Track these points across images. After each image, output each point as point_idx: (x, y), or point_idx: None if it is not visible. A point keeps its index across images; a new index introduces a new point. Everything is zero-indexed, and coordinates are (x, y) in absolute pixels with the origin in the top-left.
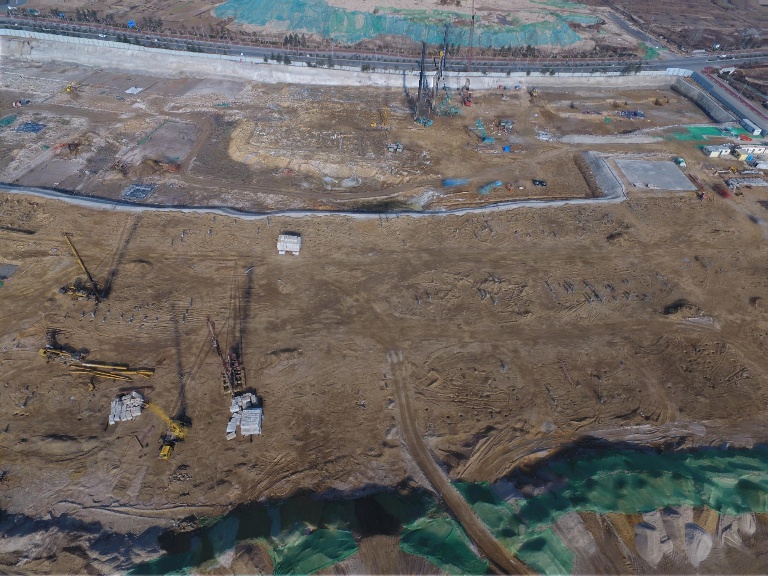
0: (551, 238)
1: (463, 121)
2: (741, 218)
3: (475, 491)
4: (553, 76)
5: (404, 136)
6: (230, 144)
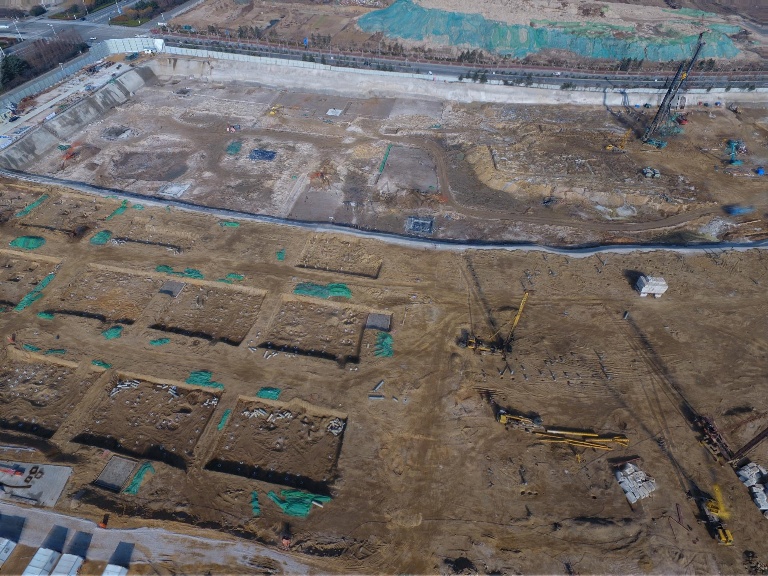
0: None
1: (690, 141)
2: None
3: None
4: (751, 92)
5: (646, 159)
6: (476, 170)
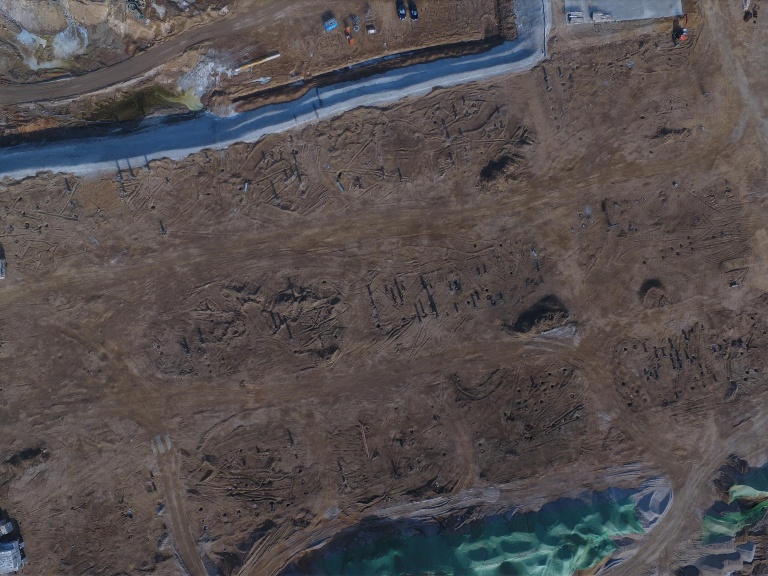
0: (393, 186)
1: None
2: (720, 90)
3: None
4: None
5: None
6: None
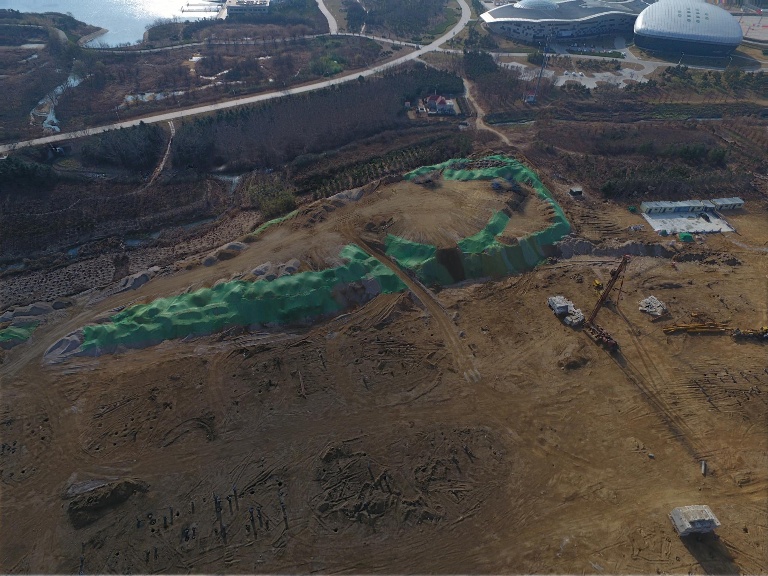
0: None
1: None
2: None
3: (392, 285)
4: None
5: None
6: None
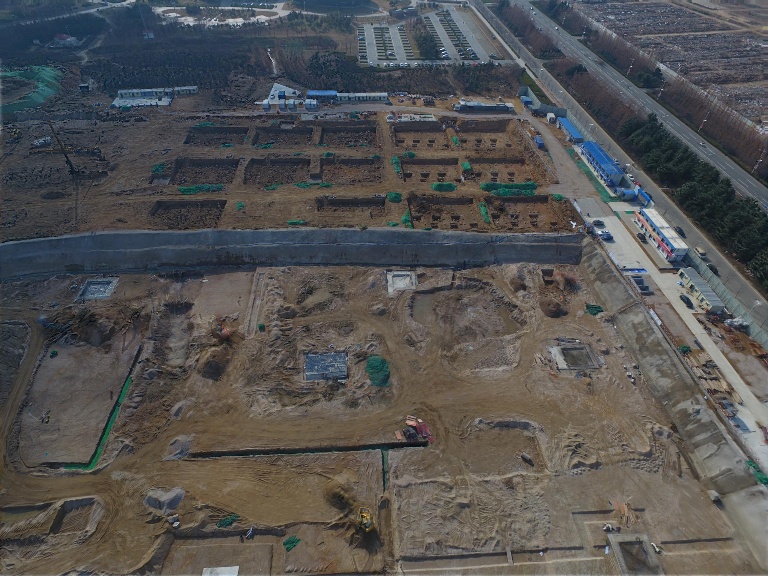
0: None
1: None
2: None
3: None
4: None
5: None
6: None
